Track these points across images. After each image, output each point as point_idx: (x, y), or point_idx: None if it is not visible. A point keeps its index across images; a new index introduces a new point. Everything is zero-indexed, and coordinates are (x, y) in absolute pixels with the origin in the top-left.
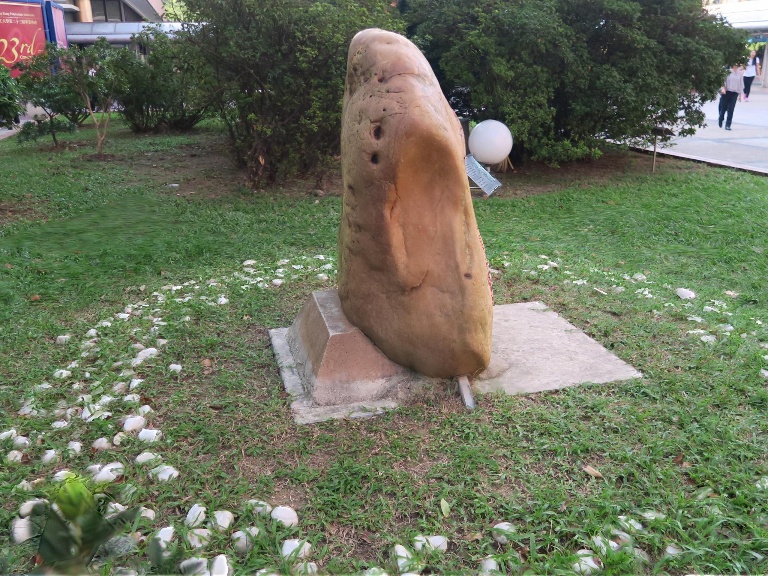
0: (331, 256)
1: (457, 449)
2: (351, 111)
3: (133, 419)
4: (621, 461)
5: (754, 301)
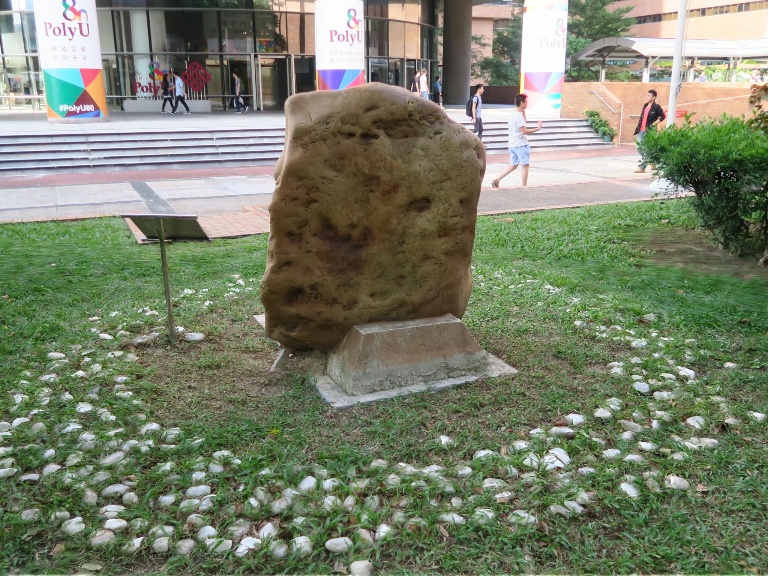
0: (28, 410)
1: (518, 331)
2: (452, 145)
3: (561, 429)
4: (503, 304)
5: (256, 273)
